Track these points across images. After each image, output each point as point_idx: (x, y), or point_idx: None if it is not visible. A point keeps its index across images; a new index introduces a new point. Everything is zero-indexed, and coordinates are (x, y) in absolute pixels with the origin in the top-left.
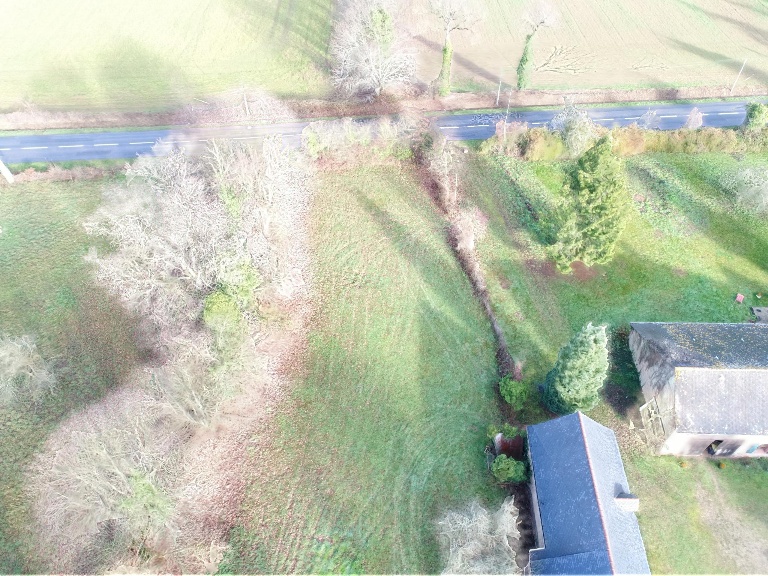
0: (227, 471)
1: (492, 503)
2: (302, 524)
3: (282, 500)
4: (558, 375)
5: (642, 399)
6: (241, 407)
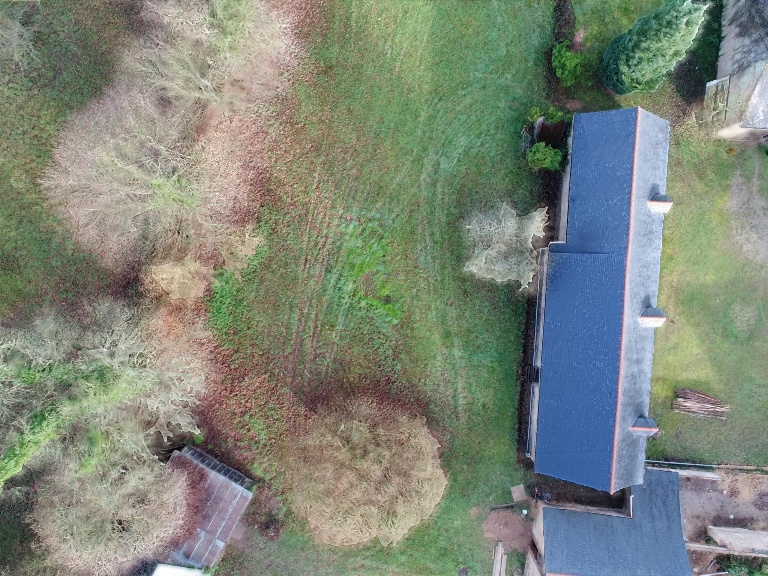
0: (248, 147)
1: (520, 187)
2: (330, 204)
3: (308, 180)
4: (626, 53)
5: (714, 72)
6: (253, 72)
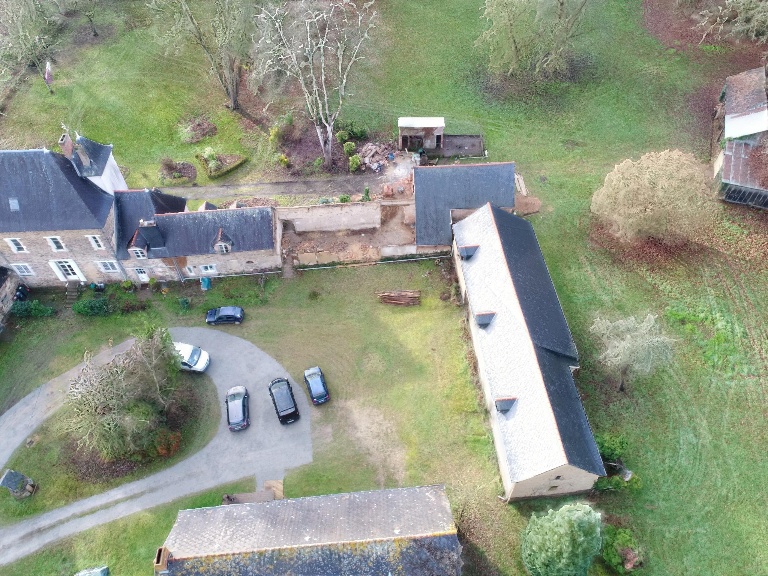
0: None
1: (609, 429)
2: None
3: None
4: None
5: None
6: None
